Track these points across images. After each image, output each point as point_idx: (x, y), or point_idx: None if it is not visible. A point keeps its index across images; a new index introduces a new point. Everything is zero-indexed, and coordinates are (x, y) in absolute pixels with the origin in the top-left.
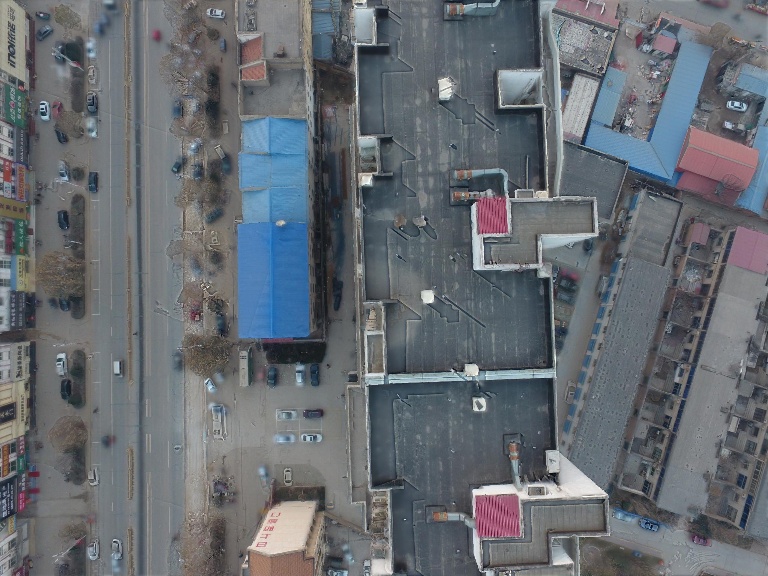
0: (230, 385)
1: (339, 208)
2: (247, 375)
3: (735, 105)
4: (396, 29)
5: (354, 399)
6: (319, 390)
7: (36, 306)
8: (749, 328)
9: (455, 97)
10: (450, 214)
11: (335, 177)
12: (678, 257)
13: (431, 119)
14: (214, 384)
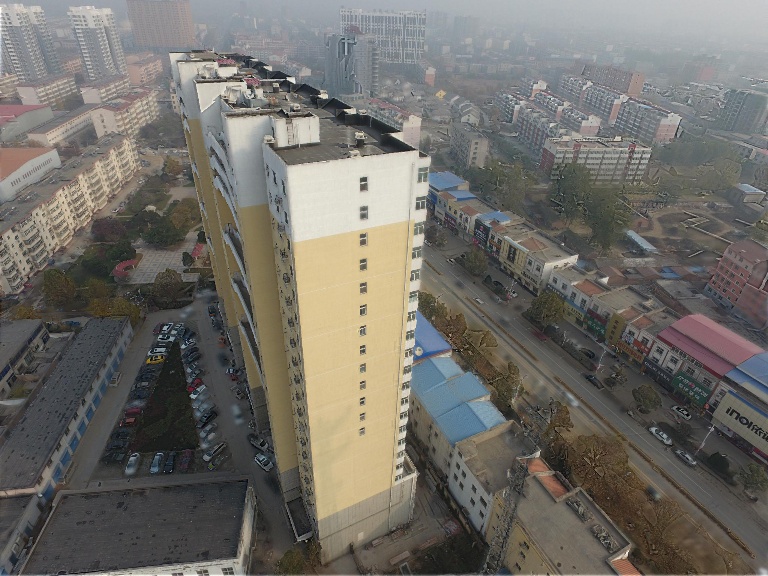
0: None
1: None
2: None
3: None
4: None
5: None
6: None
7: None
8: None
9: None
10: None
11: None
12: None
13: None
14: None
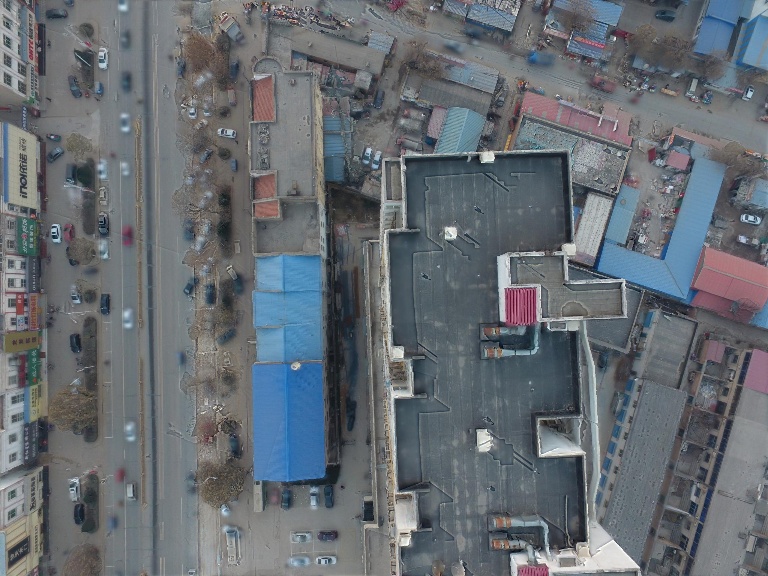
0: (244, 507)
1: (352, 327)
2: (261, 500)
3: (749, 219)
4: (432, 368)
5: (370, 539)
6: (333, 511)
7: (49, 431)
8: (766, 452)
9: (493, 438)
10: (489, 558)
11: (348, 296)
12: (693, 373)
13: (468, 460)
14: (228, 506)
